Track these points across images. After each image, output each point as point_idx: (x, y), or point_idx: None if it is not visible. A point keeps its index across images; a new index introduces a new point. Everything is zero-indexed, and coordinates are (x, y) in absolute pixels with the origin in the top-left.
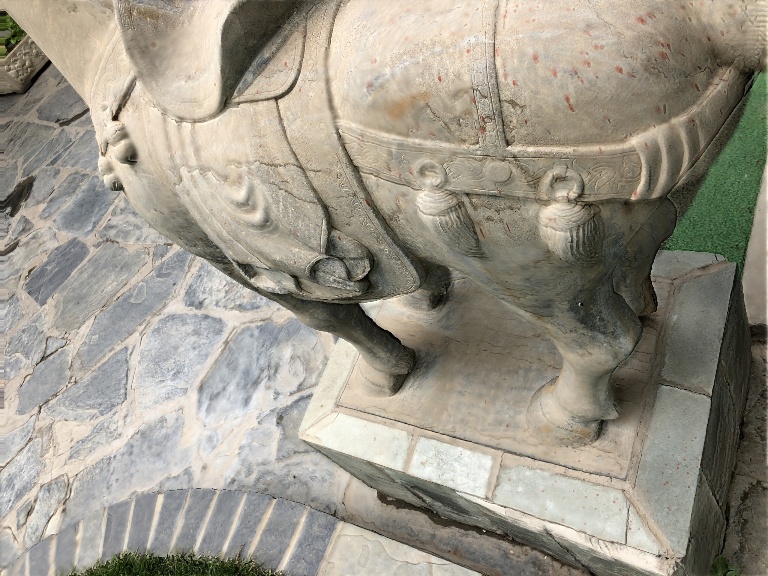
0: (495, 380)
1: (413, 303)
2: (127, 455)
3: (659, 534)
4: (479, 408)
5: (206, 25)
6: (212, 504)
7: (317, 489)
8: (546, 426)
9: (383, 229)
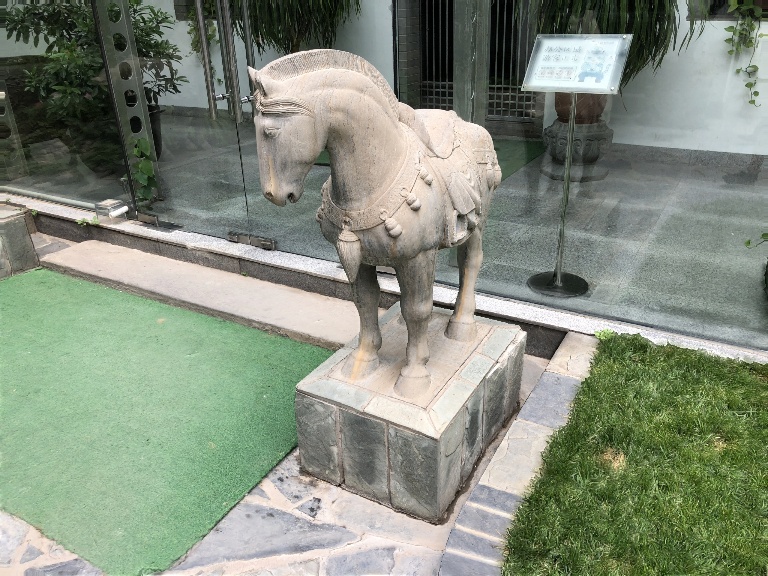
0: (437, 348)
1: (373, 366)
2: None
3: (513, 327)
4: (450, 354)
5: (429, 133)
6: None
7: (426, 571)
8: (471, 328)
9: (480, 185)
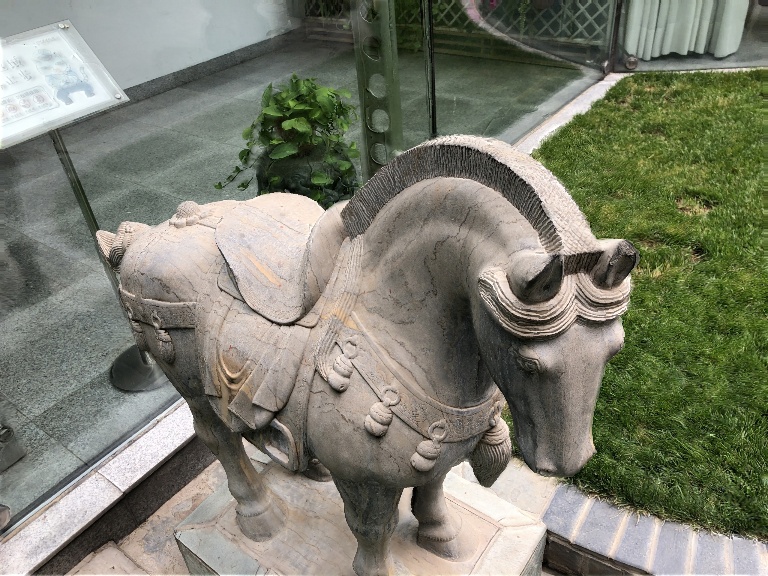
0: None
1: None
2: None
3: None
4: None
5: None
6: (693, 573)
7: None
8: None
9: None
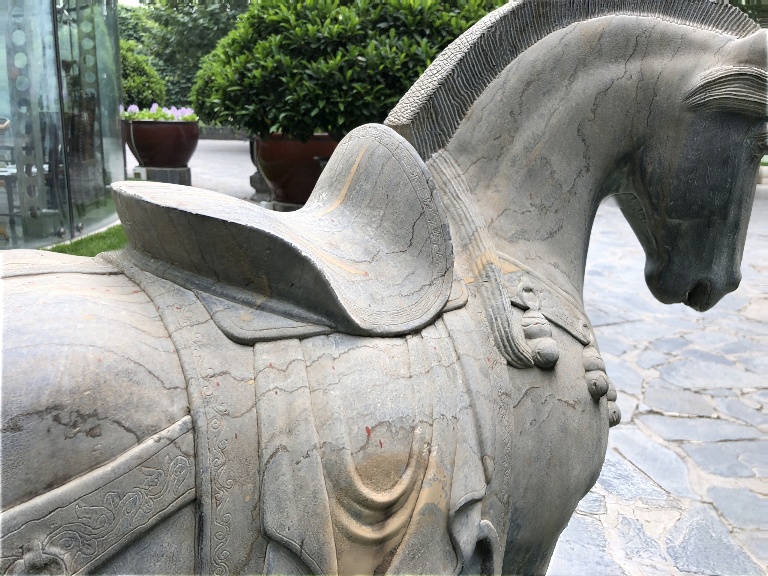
0: None
1: None
2: (598, 560)
3: None
4: None
5: None
6: None
7: None
8: None
9: None
